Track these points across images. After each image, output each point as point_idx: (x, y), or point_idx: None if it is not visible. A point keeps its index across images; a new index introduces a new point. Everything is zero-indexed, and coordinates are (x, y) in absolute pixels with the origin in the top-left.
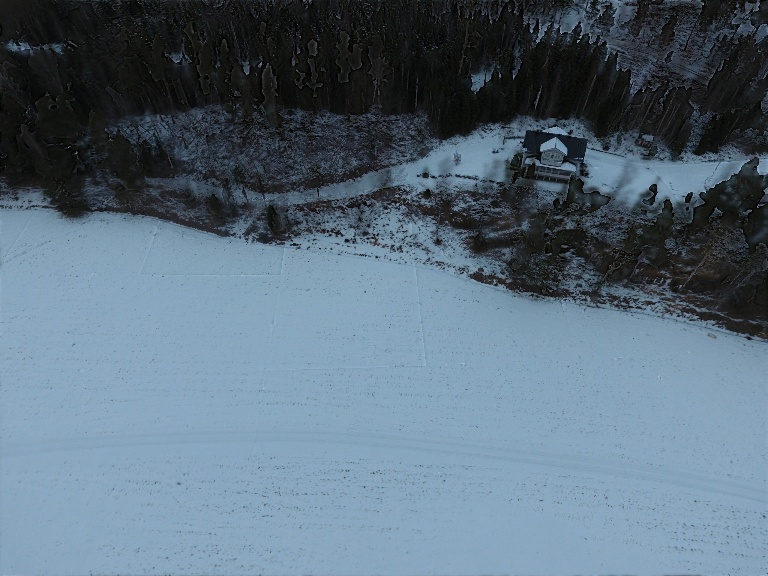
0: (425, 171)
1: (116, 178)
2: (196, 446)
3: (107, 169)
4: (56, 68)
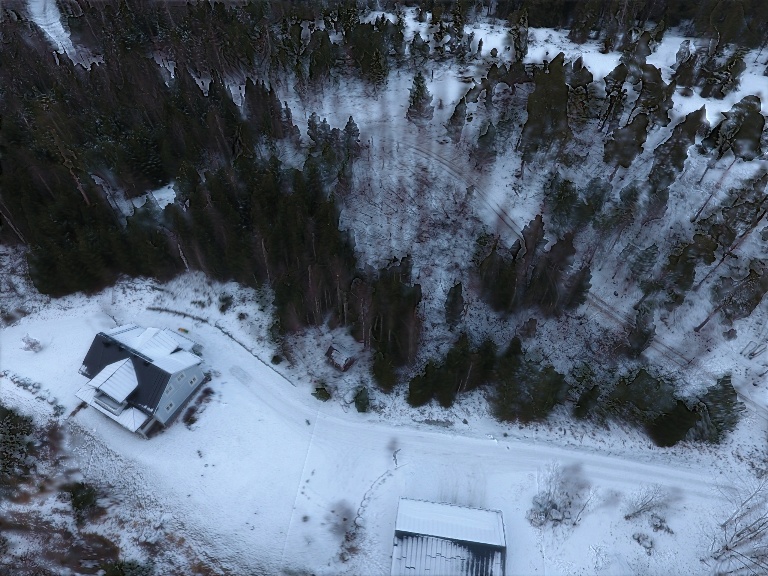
0: None
1: None
2: None
3: None
4: None
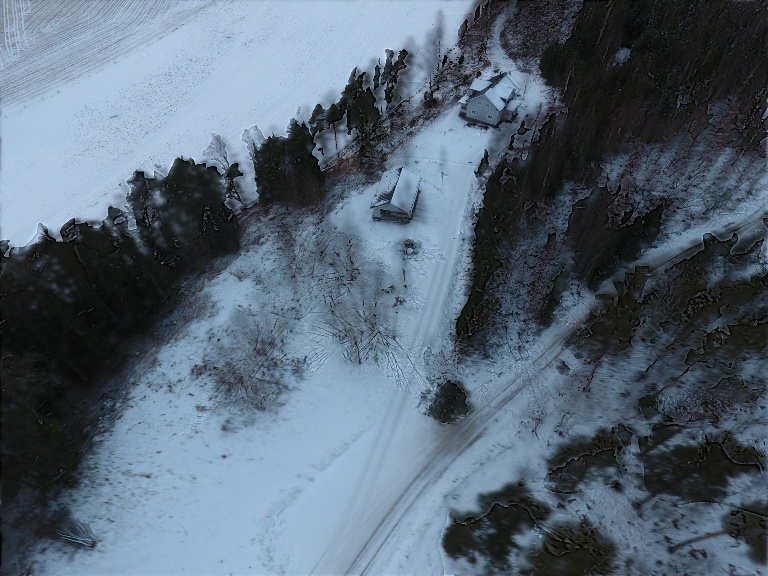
0: None
1: None
2: None
3: None
4: None
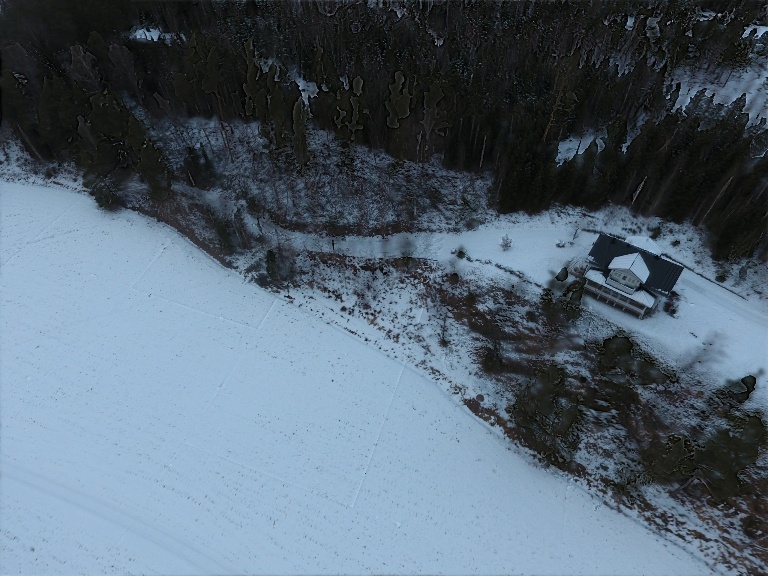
0: (462, 249)
1: (147, 183)
2: (72, 510)
3: (141, 173)
4: (132, 64)
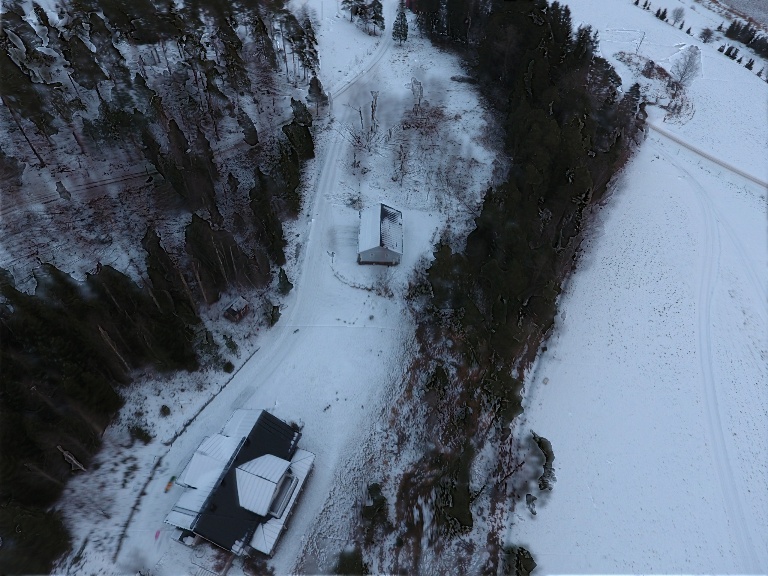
0: None
1: None
2: None
3: None
4: None
